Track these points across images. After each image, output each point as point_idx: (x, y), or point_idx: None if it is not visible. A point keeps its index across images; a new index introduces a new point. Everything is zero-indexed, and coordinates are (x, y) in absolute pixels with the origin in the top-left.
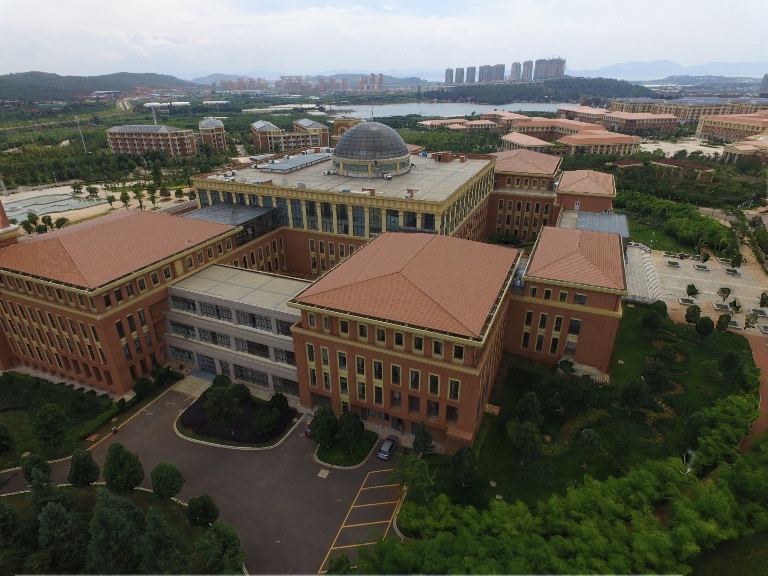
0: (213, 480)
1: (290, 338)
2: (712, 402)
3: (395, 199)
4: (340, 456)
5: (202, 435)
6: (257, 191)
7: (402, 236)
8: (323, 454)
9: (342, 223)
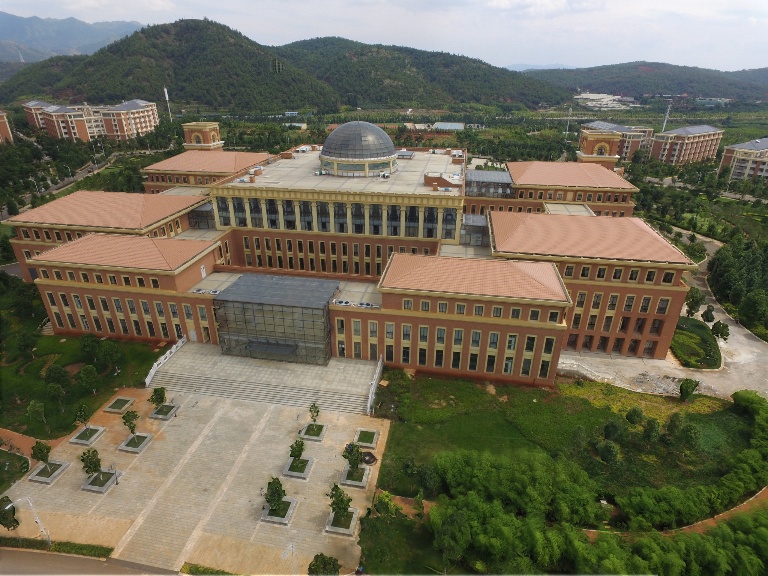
0: None
1: None
2: None
3: None
4: None
5: None
6: None
7: None
8: None
9: None
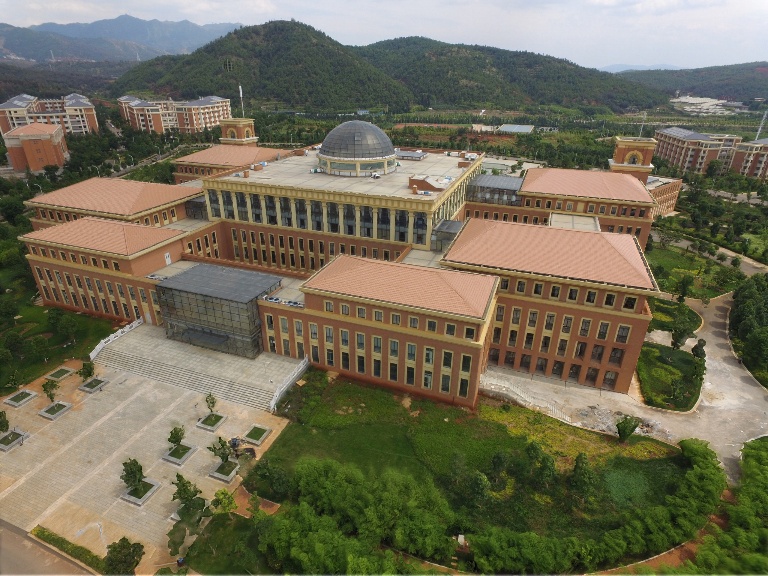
0: None
1: None
2: None
3: None
4: None
5: None
6: None
7: None
8: None
9: None
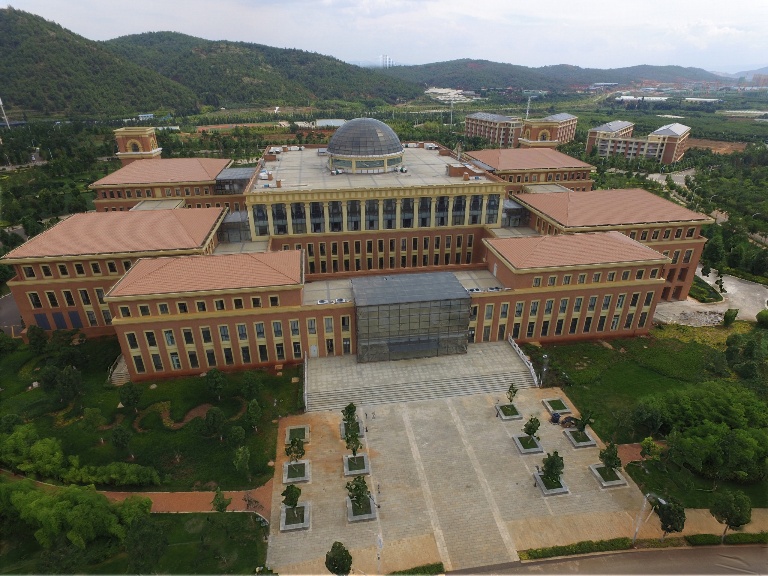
0: None
1: None
2: (77, 449)
3: None
4: None
5: None
6: None
7: None
8: None
9: None
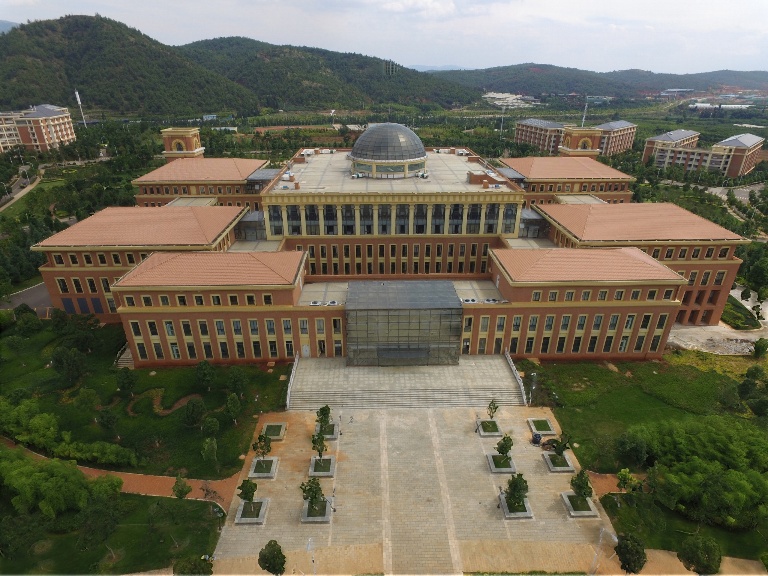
0: None
1: None
2: (73, 426)
3: None
4: None
5: None
6: None
7: None
8: None
9: None
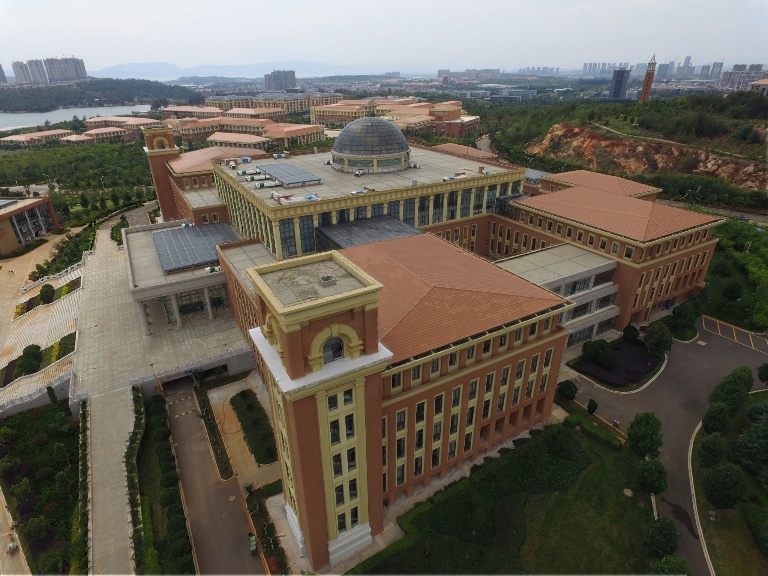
0: (699, 385)
1: (600, 286)
2: None
3: (497, 174)
4: (689, 332)
5: (641, 380)
6: (366, 201)
7: (551, 196)
8: (686, 337)
9: (450, 210)
